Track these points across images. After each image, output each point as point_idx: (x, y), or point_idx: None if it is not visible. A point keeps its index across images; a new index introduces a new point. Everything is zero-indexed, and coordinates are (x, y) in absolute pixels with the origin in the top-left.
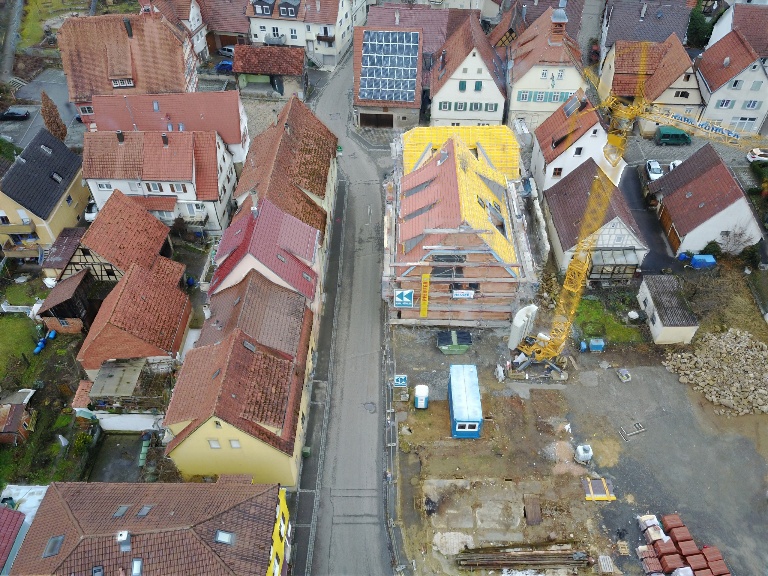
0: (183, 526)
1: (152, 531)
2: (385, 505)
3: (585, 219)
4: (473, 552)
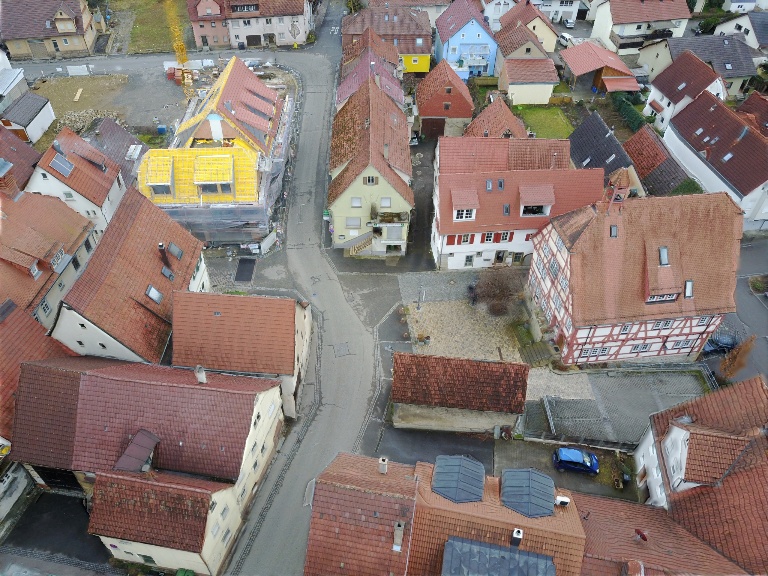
0: (369, 8)
1: (379, 7)
2: (303, 89)
3: (123, 141)
4: (268, 78)
